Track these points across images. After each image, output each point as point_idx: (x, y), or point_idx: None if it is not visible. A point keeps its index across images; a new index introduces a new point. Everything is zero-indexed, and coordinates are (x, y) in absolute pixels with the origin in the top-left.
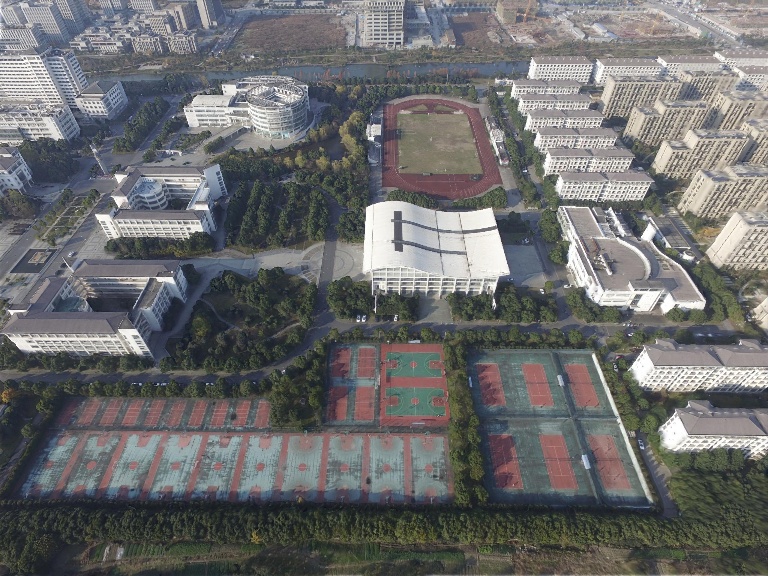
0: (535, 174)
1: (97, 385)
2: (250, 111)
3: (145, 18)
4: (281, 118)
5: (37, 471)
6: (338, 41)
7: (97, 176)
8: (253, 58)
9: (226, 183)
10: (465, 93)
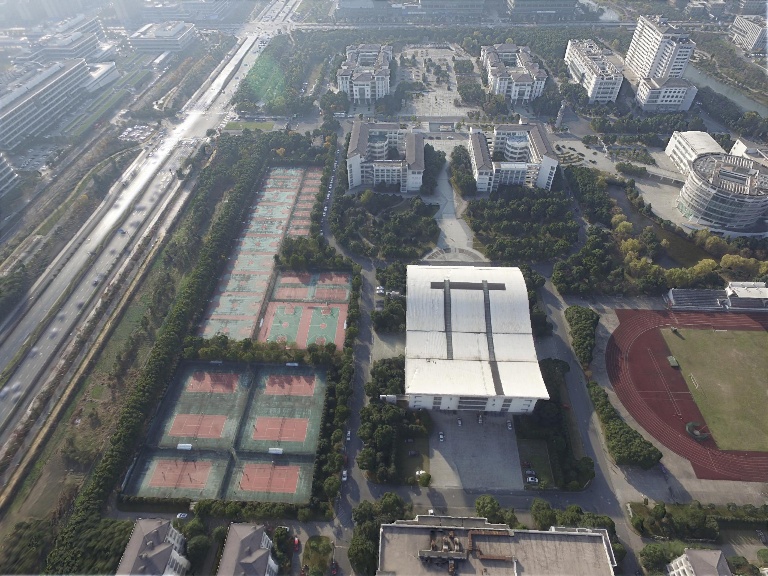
0: None
1: (325, 168)
2: None
3: None
4: (696, 193)
5: (283, 168)
6: None
7: (550, 125)
8: None
9: (557, 183)
10: None
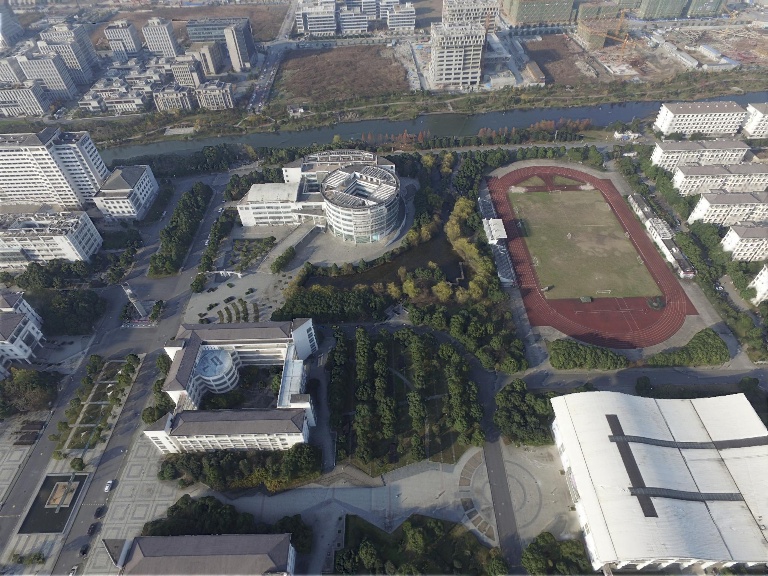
0: (738, 295)
1: None
2: (327, 208)
3: (165, 63)
4: (372, 220)
5: None
6: (399, 83)
7: (132, 321)
8: (302, 112)
9: (316, 335)
10: (584, 155)
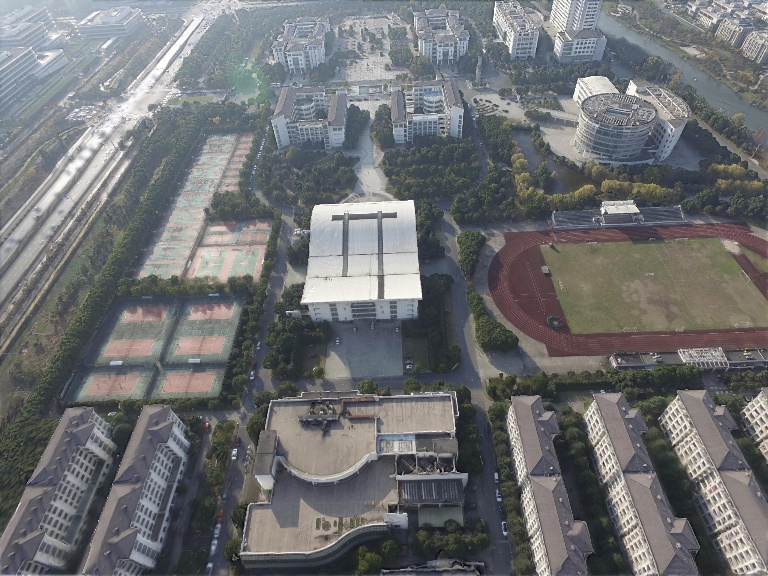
0: None
1: (256, 132)
2: None
3: None
4: (585, 129)
5: (219, 135)
6: None
7: (471, 81)
8: None
9: (466, 131)
10: None
